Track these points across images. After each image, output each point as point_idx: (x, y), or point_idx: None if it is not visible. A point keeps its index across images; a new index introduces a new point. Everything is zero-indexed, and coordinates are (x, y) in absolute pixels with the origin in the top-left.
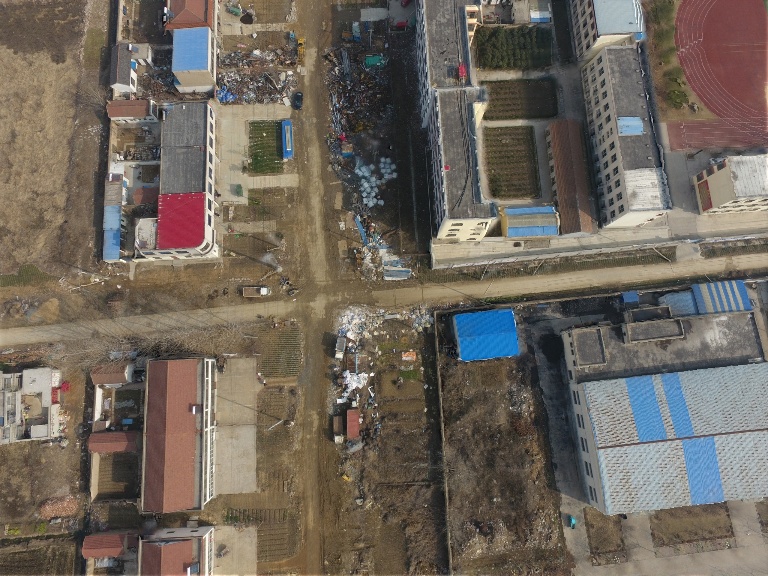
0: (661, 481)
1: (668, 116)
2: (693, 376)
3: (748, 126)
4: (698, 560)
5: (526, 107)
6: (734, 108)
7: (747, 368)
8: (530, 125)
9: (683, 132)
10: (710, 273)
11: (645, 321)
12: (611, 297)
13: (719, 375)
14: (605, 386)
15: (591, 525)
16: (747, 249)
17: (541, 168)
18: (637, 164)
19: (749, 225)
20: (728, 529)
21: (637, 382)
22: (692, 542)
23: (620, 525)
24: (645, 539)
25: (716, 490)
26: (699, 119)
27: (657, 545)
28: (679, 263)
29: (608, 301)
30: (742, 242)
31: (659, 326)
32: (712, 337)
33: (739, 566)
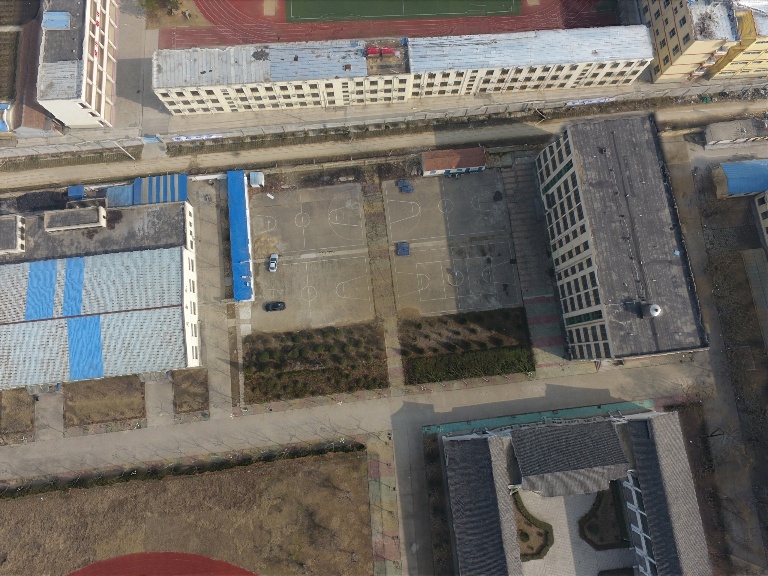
0: (41, 358)
1: (161, 23)
2: (99, 260)
3: (240, 32)
4: (105, 439)
5: (18, 14)
6: (230, 15)
7: (153, 252)
8: (18, 31)
9: (174, 38)
10: (172, 170)
11: (64, 209)
12: (67, 193)
13: (125, 259)
14: (7, 269)
15: (4, 407)
16: (214, 148)
17: (17, 71)
18: (60, 57)
19: (220, 125)
20: (140, 410)
21: (41, 266)
22: (102, 423)
23: (33, 407)
24: (56, 420)
25: (96, 366)
26: (192, 26)
27: (67, 426)
28: (143, 161)
29: (64, 197)
30: (210, 141)
31: (79, 214)
32: (140, 226)
33: (144, 445)
